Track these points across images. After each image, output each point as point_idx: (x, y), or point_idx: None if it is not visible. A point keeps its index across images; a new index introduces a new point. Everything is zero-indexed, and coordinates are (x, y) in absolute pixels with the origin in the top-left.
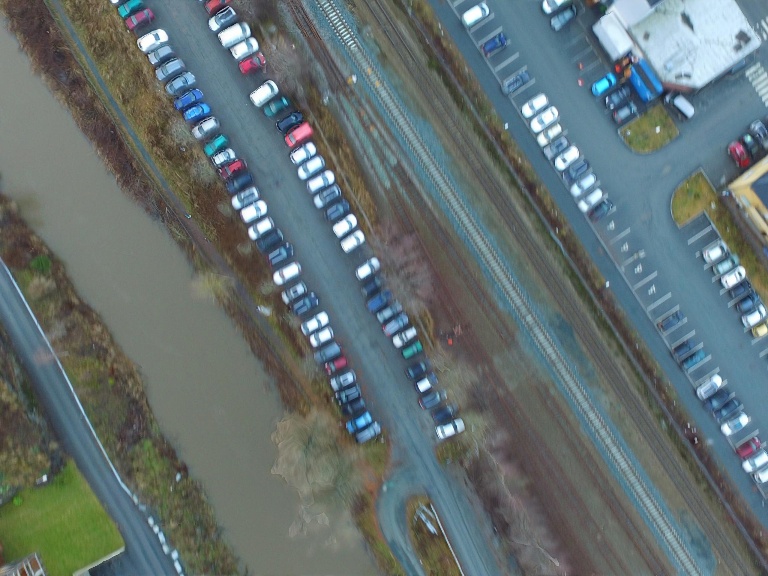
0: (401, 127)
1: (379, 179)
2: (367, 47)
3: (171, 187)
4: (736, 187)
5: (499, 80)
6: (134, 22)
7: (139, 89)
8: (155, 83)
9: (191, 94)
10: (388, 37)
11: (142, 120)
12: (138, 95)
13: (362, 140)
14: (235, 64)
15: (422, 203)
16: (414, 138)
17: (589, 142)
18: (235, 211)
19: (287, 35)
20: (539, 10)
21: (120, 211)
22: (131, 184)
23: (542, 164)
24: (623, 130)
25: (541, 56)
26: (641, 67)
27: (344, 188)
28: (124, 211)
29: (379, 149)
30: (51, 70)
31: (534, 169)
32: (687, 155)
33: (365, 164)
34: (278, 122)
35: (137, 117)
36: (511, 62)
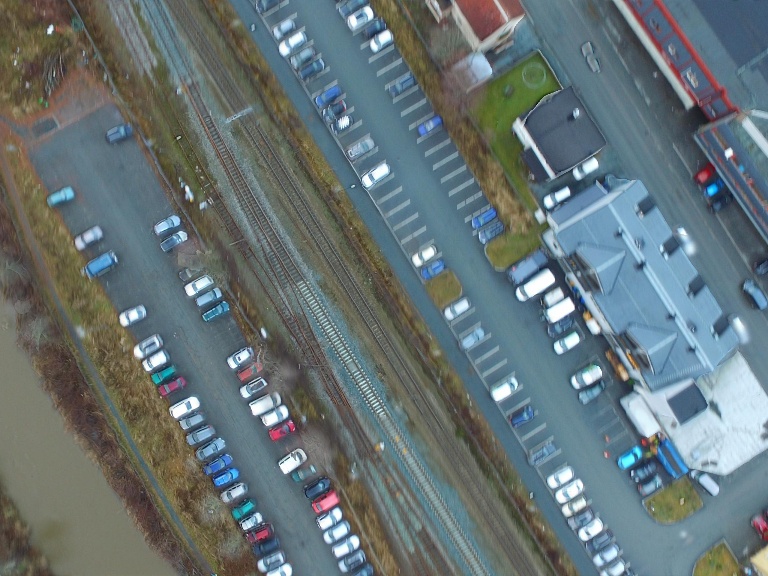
0: (427, 493)
1: (403, 544)
2: (396, 415)
3: (198, 547)
4: (758, 566)
5: (525, 450)
6: (167, 390)
7: (170, 452)
8: (186, 448)
9: (221, 460)
10: (417, 406)
11: (172, 483)
12: (168, 458)
13: (388, 506)
14: (265, 429)
15: (445, 568)
16: (439, 504)
17: (613, 512)
18: (261, 574)
19: (317, 402)
20: (567, 382)
21: (147, 566)
22: (159, 543)
23: (566, 533)
24: (647, 501)
25: (568, 427)
26: (668, 449)
27: (369, 552)
28: (151, 566)
29: (404, 515)
30: (84, 430)
31: (557, 537)
32: (710, 526)
33: (390, 529)
34: (306, 489)
35: (167, 479)
36: (538, 432)
